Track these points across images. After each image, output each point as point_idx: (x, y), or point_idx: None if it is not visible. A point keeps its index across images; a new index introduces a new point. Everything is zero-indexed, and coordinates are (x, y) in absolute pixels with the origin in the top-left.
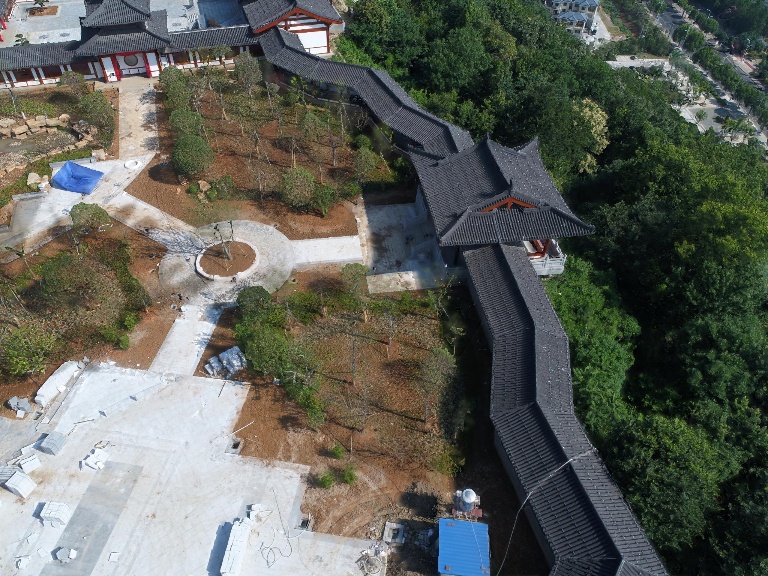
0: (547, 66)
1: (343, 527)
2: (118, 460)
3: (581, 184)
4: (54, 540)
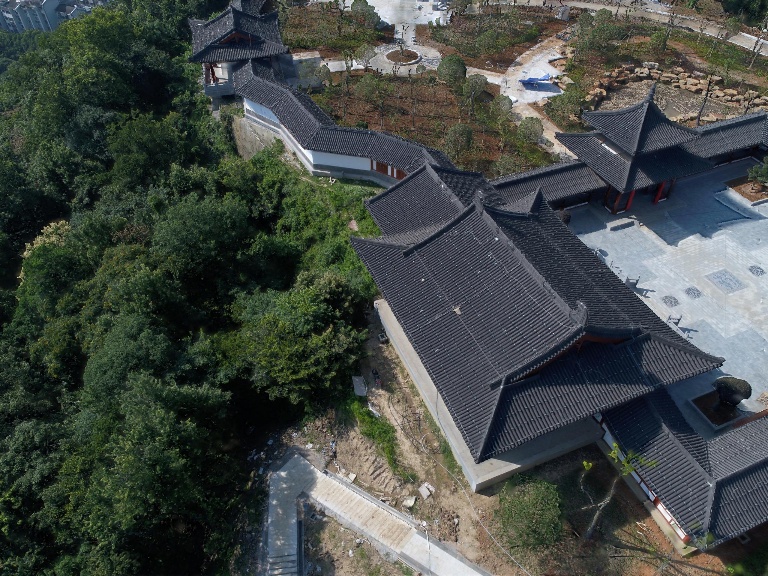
0: (78, 233)
1: (324, 3)
2: (410, 8)
3: None
4: None
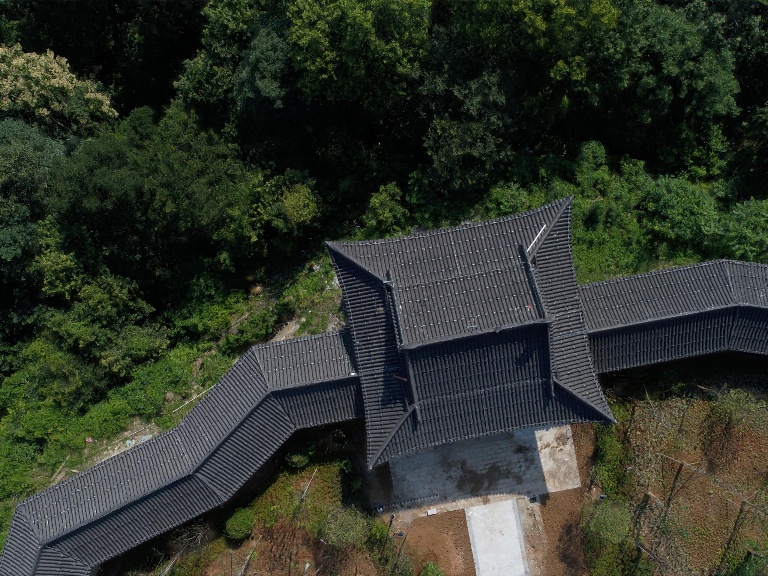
0: None
1: None
2: None
3: (278, 150)
4: None
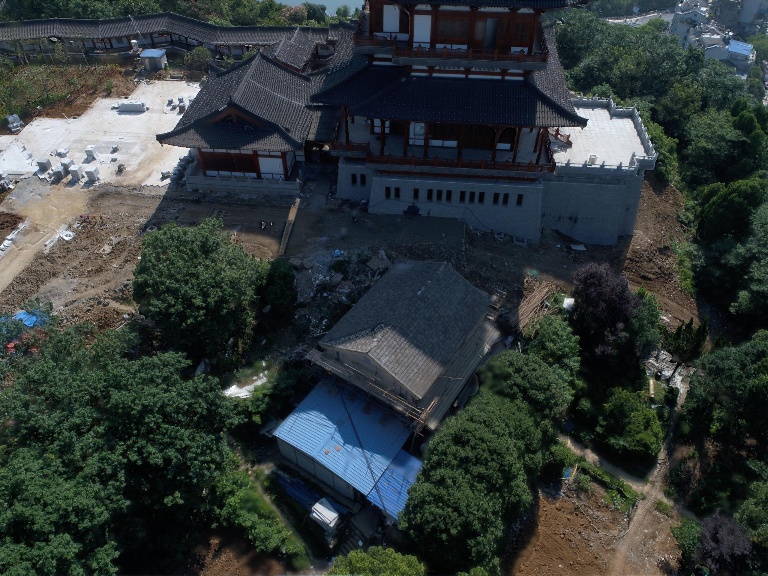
0: None
1: (132, 88)
2: (66, 147)
3: None
4: (106, 155)
